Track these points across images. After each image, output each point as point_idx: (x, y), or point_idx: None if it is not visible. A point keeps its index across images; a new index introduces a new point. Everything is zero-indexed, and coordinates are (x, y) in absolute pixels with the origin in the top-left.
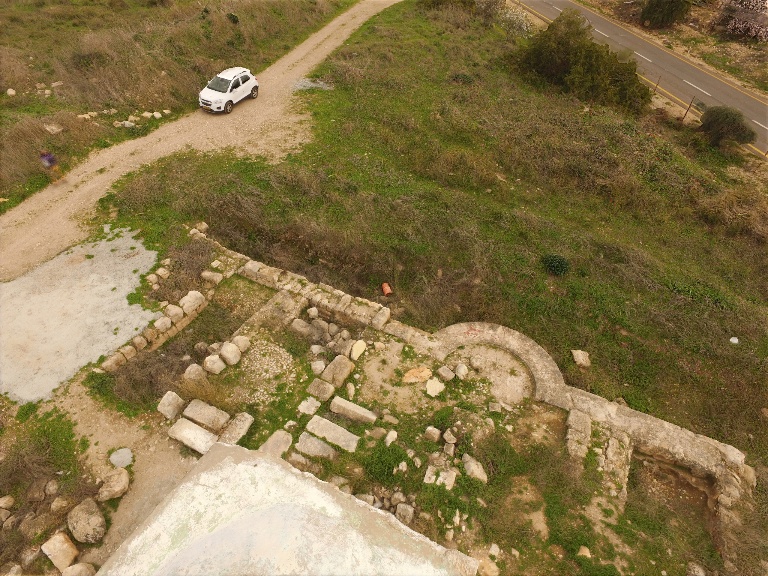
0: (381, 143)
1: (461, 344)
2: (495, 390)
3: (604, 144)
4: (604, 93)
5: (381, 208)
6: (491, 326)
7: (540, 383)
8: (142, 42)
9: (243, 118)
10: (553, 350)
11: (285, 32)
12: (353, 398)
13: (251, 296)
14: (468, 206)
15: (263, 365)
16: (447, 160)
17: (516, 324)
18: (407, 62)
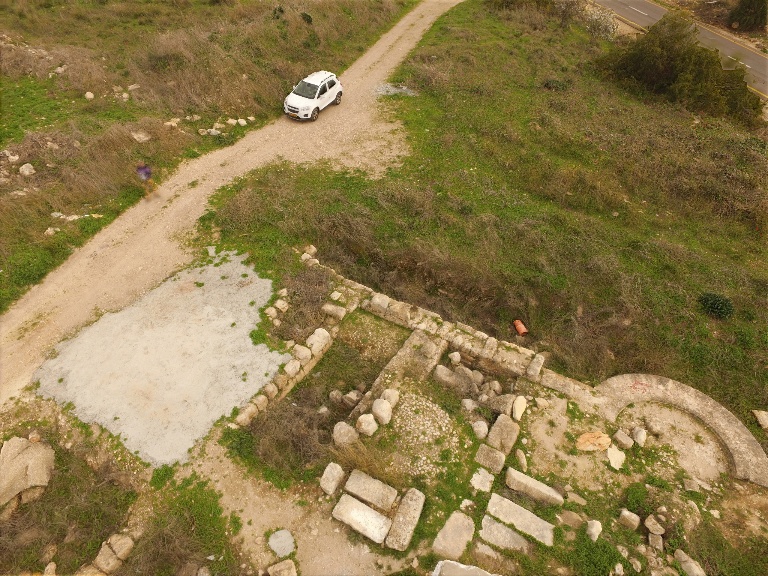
0: (485, 157)
1: (630, 401)
2: (683, 462)
3: (732, 162)
4: (714, 103)
5: (504, 233)
6: (659, 379)
7: (738, 456)
8: (217, 43)
9: (331, 126)
10: (729, 409)
11: (356, 32)
12: (527, 469)
13: (381, 335)
14: (598, 232)
15: (418, 425)
16: (564, 178)
17: (681, 376)
18: (490, 66)
